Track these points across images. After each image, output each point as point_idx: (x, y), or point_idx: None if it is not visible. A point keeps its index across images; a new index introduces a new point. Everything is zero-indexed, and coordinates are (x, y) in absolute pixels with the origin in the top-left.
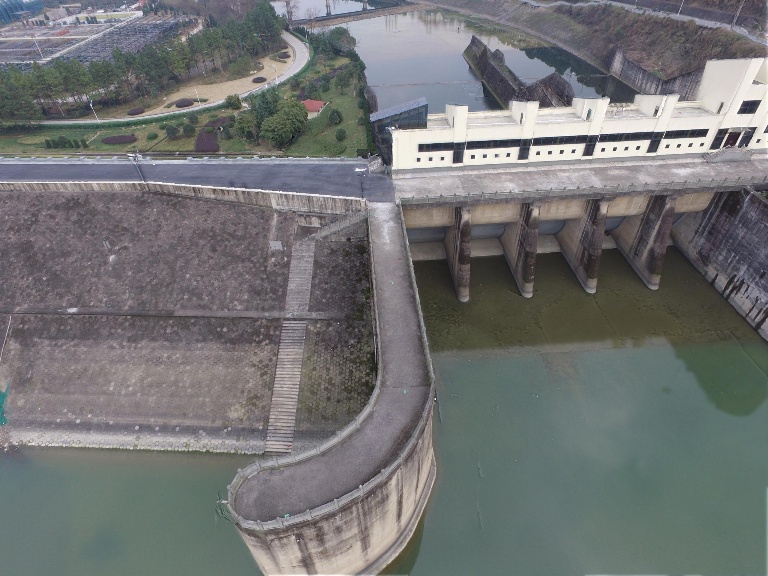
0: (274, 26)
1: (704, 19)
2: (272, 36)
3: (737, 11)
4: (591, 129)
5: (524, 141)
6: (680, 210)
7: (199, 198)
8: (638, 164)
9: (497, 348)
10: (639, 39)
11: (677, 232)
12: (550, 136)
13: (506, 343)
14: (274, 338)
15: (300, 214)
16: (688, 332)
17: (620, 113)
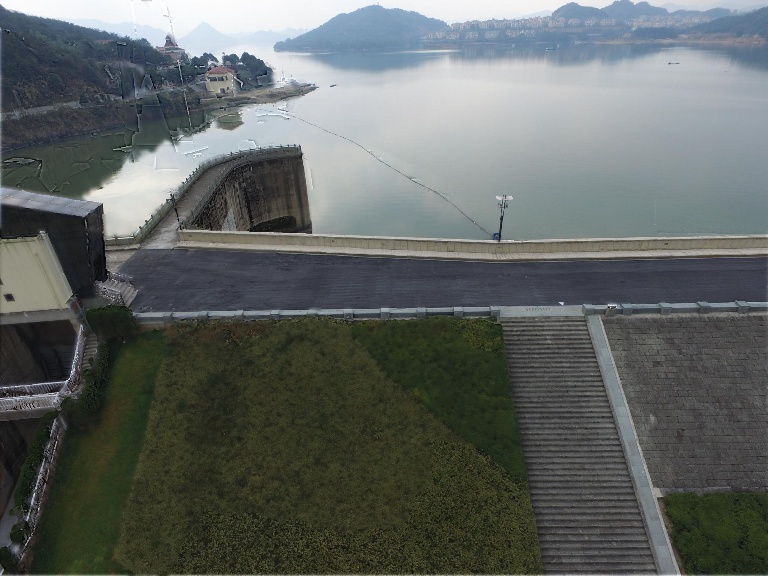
0: None
1: None
2: None
3: None
4: None
5: None
6: None
7: None
8: None
9: None
10: None
11: None
12: None
13: None
14: None
15: None
16: None
17: None
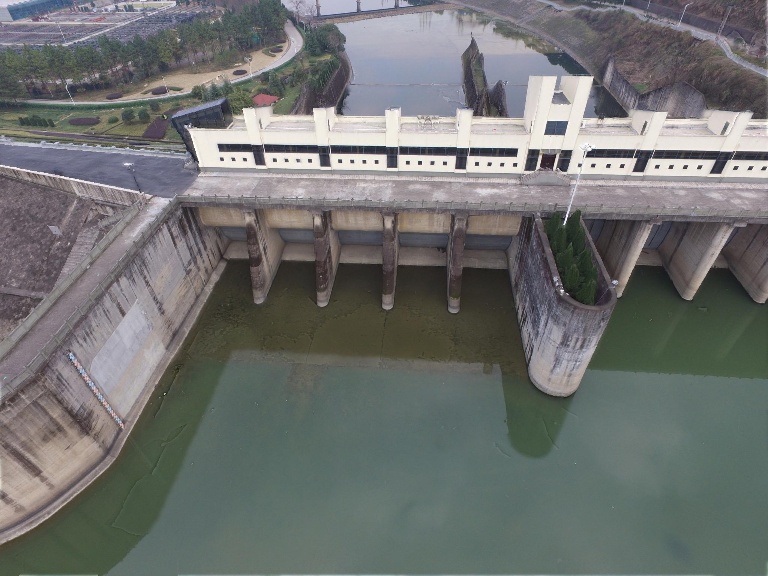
0: (272, 20)
1: (706, 30)
2: (270, 30)
3: (721, 23)
4: (387, 140)
5: (322, 148)
6: (491, 232)
7: (20, 180)
8: (446, 180)
9: (256, 353)
10: (637, 49)
11: (509, 256)
12: (348, 145)
13: (268, 349)
14: None
15: (96, 203)
16: (456, 361)
17: (429, 126)
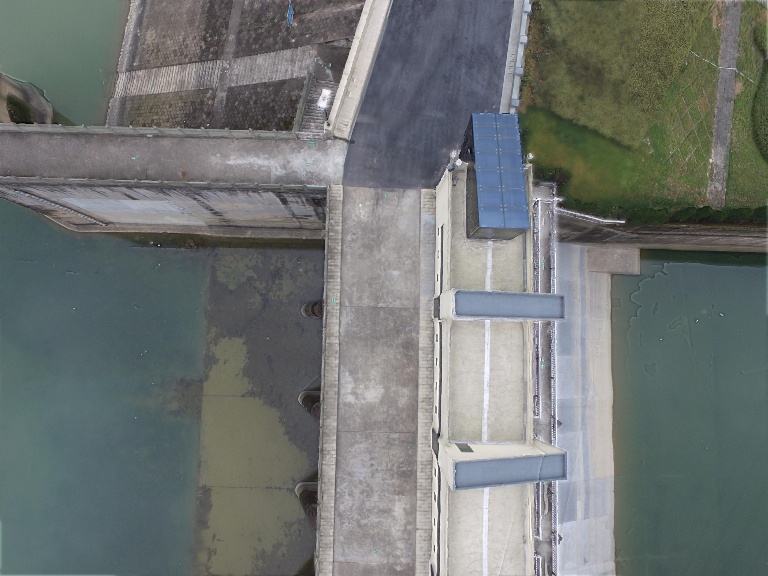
0: None
1: None
2: None
3: None
4: None
5: None
6: None
7: None
8: None
9: (218, 331)
10: None
11: None
12: None
13: (224, 344)
14: (206, 54)
15: None
16: None
17: None
